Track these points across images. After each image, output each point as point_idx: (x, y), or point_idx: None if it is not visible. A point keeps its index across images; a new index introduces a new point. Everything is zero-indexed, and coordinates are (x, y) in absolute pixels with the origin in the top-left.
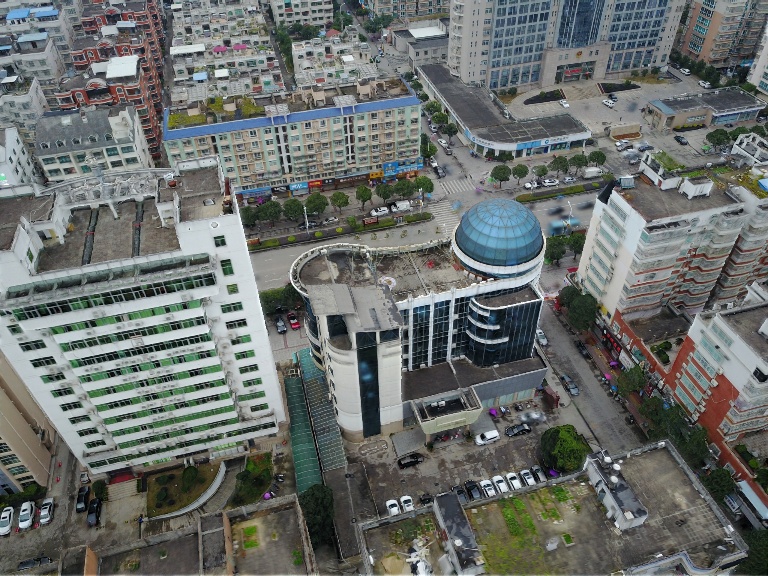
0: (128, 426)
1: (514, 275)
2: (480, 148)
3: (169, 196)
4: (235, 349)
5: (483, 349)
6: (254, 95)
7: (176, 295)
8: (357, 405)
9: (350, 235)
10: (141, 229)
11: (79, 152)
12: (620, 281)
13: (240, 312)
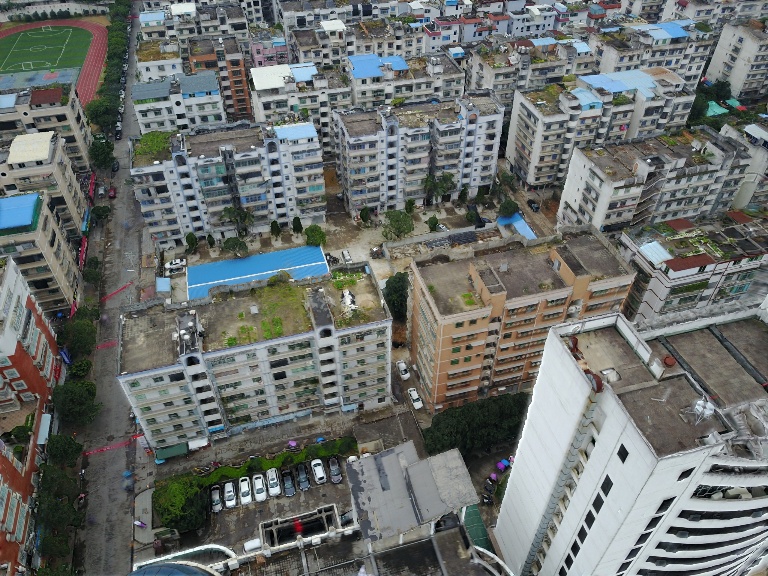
0: None
1: None
2: None
3: (680, 388)
4: None
5: None
6: None
7: None
8: None
9: None
10: None
11: None
12: None
13: None
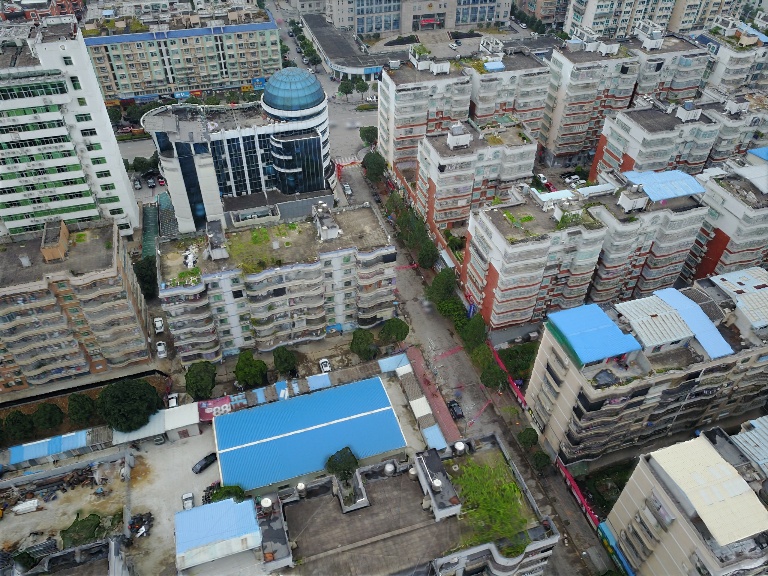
0: (15, 213)
1: (300, 119)
2: (338, 74)
3: None
4: (91, 155)
5: (285, 178)
6: (144, 19)
7: (40, 99)
8: (188, 210)
9: None
10: (17, 58)
11: None
12: (392, 138)
13: (90, 122)
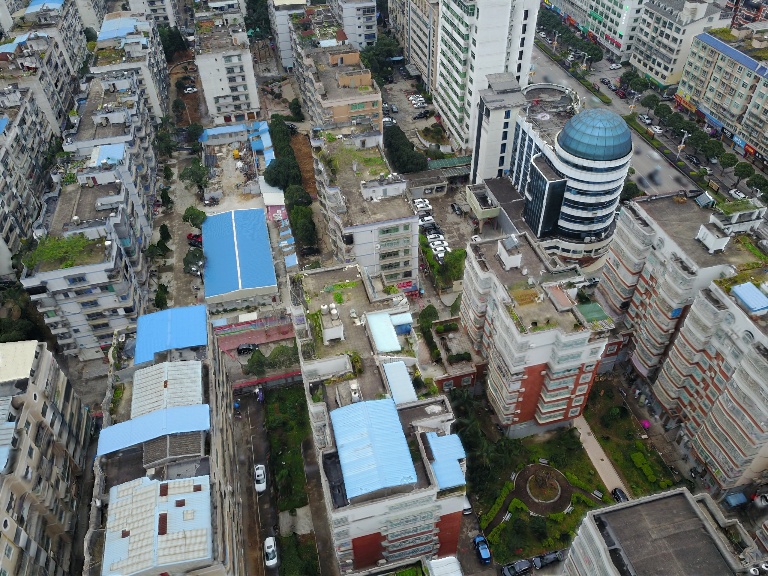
0: (442, 83)
1: None
2: None
3: None
4: None
5: None
6: None
7: None
8: None
9: (692, 182)
10: None
11: (659, 15)
12: None
13: None
